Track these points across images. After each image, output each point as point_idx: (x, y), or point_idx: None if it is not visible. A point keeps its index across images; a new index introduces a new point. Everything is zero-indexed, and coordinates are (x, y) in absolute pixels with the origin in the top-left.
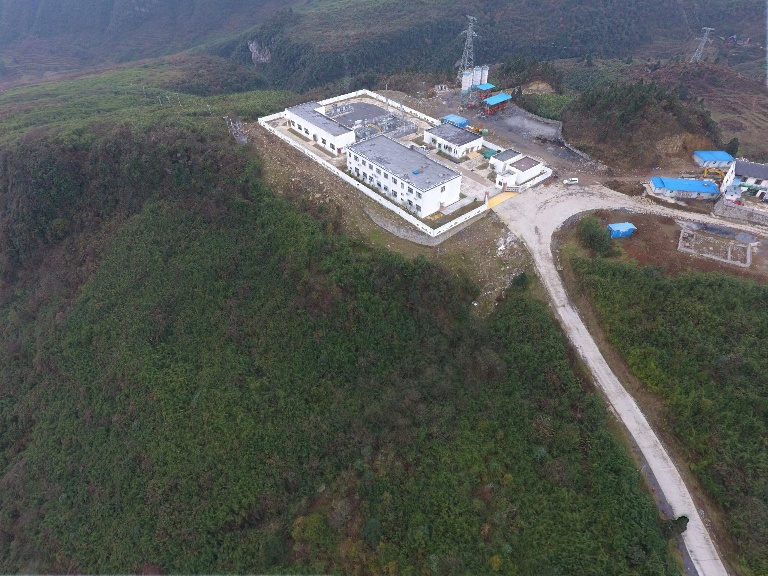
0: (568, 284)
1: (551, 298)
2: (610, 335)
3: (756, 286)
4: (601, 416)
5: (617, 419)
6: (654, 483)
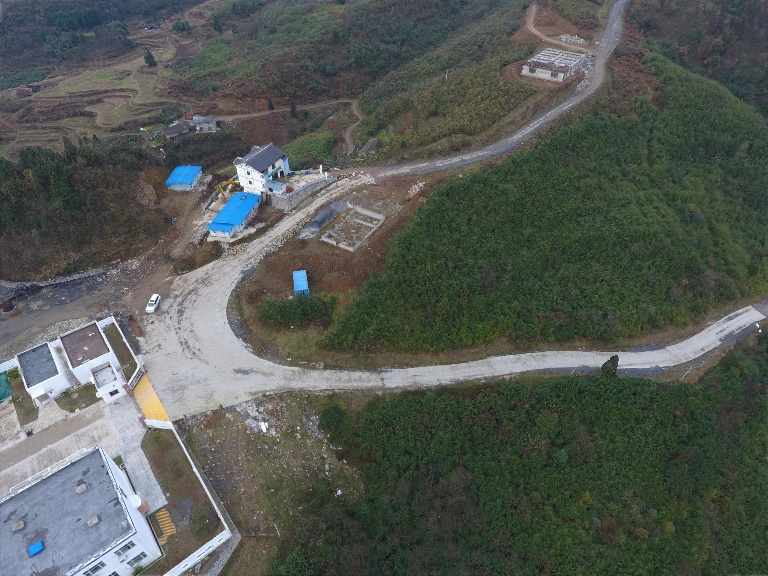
0: (348, 365)
1: (370, 389)
2: (435, 348)
3: (416, 224)
4: (523, 387)
5: (516, 376)
6: (568, 370)
